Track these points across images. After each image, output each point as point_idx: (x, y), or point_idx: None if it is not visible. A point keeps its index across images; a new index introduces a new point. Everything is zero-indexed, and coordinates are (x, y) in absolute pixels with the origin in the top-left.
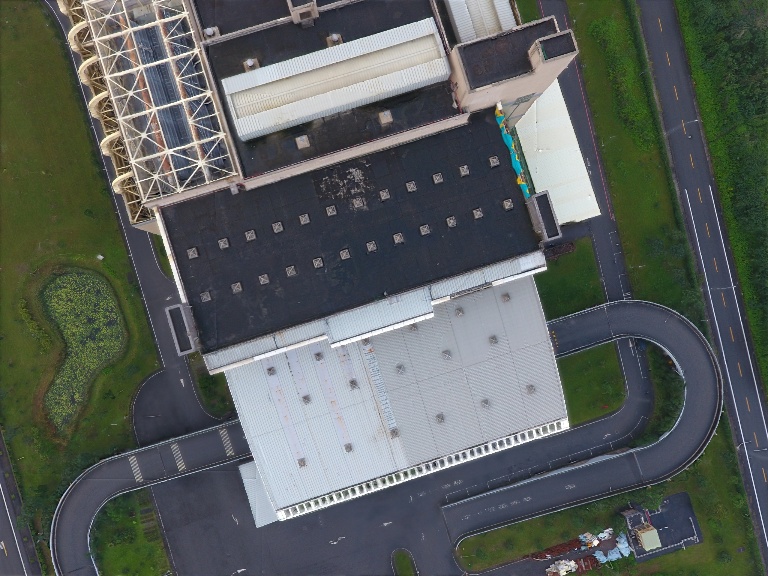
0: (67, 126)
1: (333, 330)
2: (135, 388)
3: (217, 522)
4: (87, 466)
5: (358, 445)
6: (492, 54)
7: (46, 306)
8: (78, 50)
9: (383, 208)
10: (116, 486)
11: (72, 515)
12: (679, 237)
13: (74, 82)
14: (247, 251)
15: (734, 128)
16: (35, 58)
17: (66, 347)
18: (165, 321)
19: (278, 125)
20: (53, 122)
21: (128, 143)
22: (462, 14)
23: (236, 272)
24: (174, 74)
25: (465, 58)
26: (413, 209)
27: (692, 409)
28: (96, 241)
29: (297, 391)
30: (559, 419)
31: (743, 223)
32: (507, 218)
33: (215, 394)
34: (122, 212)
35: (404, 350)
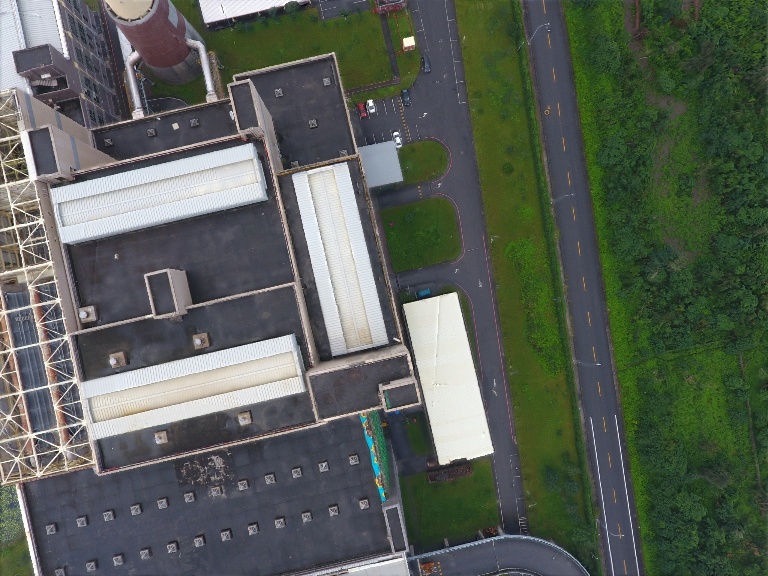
0: None
1: None
2: (31, 572)
3: None
4: None
5: None
6: (344, 384)
7: None
8: None
9: (241, 497)
10: None
11: None
12: (575, 473)
13: None
14: (105, 530)
15: (644, 361)
16: None
17: None
18: None
19: None
20: None
21: None
22: (332, 314)
23: (92, 550)
24: None
25: (317, 386)
26: (270, 500)
27: None
28: None
29: None
30: None
31: (643, 461)
32: (363, 516)
33: None
34: None
35: None
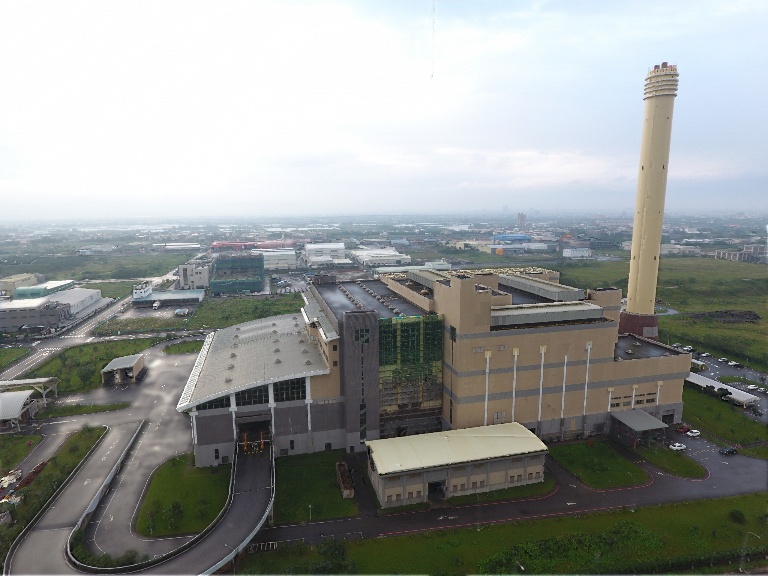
0: None
1: None
2: None
3: None
4: None
5: None
6: None
7: None
8: None
9: None
10: None
11: None
12: (343, 573)
13: None
14: None
15: None
16: None
17: None
18: None
19: (414, 275)
20: None
21: None
22: None
23: None
24: None
25: None
26: None
27: None
28: None
29: None
30: None
31: None
32: None
33: None
34: None
35: None
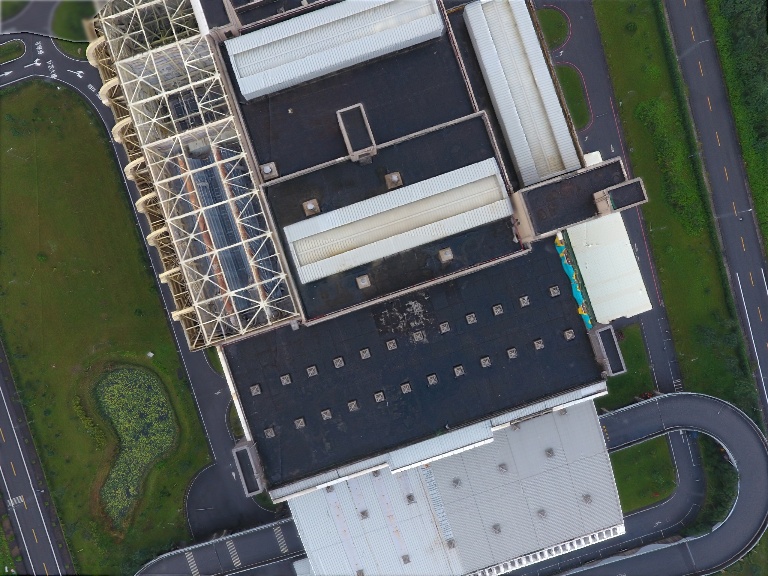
0: (114, 224)
1: (394, 458)
2: (188, 482)
3: None
4: (145, 561)
5: (415, 556)
6: (556, 197)
7: (99, 402)
8: (133, 178)
9: (443, 340)
10: None
11: None
12: (732, 326)
13: (119, 180)
14: (309, 386)
15: None
16: (80, 157)
17: (120, 442)
18: (215, 415)
19: (340, 270)
20: (100, 220)
21: (191, 286)
22: (520, 144)
23: (298, 407)
24: (234, 215)
25: (529, 202)
26: (473, 341)
27: (746, 499)
28: (146, 338)
29: (355, 506)
30: (615, 525)
31: None
32: (568, 348)
33: None
34: (170, 308)
35: (460, 464)
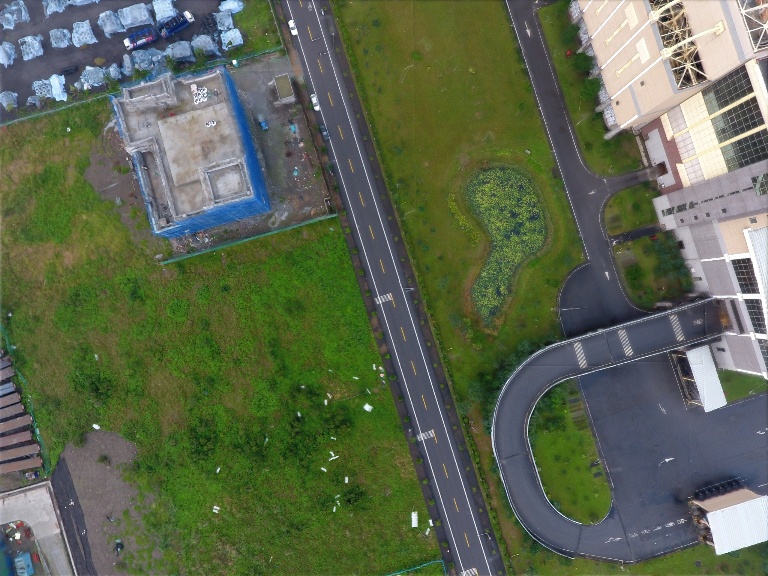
0: (489, 25)
1: None
2: (561, 280)
3: (644, 412)
4: (531, 353)
5: None
6: None
7: (471, 201)
8: None
9: None
10: (559, 372)
11: (512, 401)
12: None
13: None
14: None
15: None
16: None
17: (491, 241)
18: (589, 215)
19: None
20: (475, 21)
21: None
22: None
23: None
24: None
25: None
26: None
27: None
28: (520, 137)
29: None
30: None
31: None
32: None
33: (643, 286)
34: (544, 109)
35: None
